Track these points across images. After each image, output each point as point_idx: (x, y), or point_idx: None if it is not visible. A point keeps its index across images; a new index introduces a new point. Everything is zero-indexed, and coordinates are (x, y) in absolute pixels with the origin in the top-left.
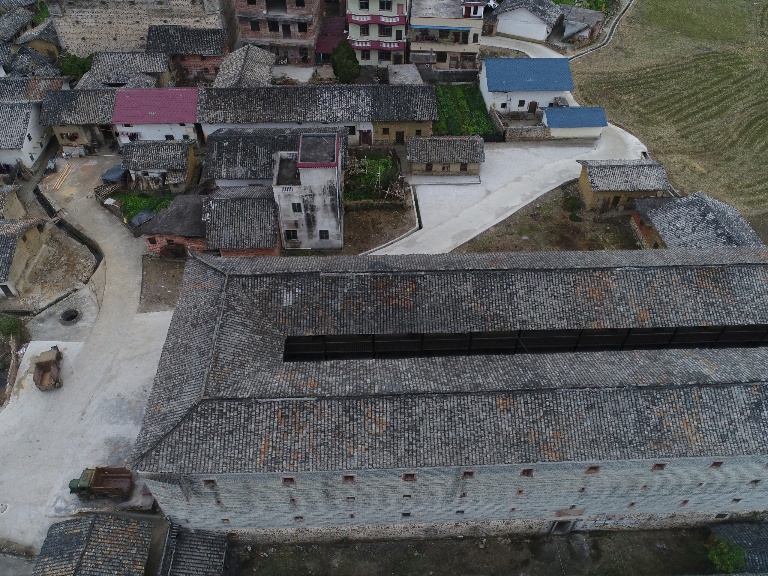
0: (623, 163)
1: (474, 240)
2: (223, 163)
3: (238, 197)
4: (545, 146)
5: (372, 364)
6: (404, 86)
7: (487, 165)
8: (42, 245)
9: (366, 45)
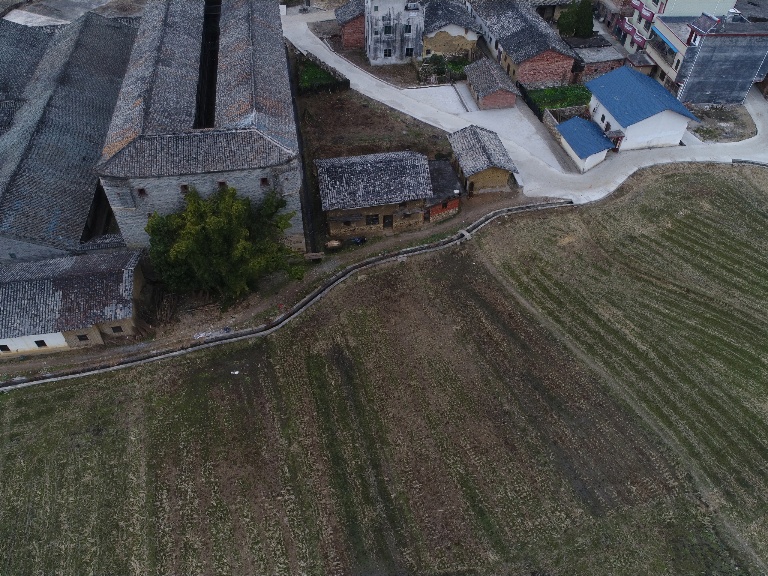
0: (492, 148)
1: (394, 110)
2: (412, 0)
3: None
4: (548, 143)
5: (200, 7)
6: (541, 36)
7: (497, 114)
8: None
9: (629, 29)
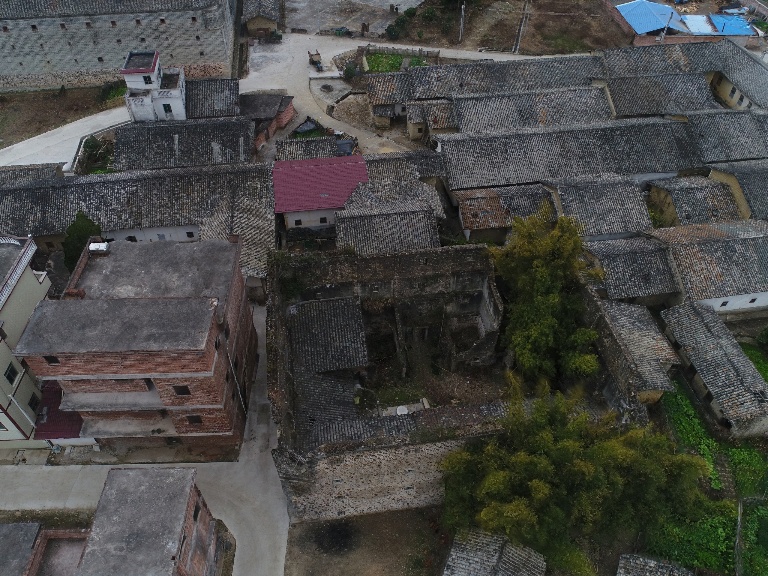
0: None
1: None
2: None
3: (214, 82)
4: None
5: None
6: (26, 188)
7: None
8: (372, 112)
9: None
